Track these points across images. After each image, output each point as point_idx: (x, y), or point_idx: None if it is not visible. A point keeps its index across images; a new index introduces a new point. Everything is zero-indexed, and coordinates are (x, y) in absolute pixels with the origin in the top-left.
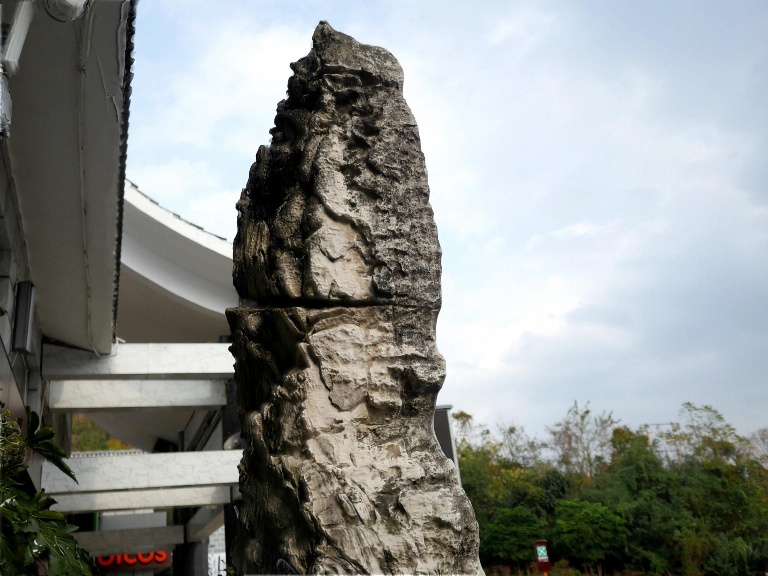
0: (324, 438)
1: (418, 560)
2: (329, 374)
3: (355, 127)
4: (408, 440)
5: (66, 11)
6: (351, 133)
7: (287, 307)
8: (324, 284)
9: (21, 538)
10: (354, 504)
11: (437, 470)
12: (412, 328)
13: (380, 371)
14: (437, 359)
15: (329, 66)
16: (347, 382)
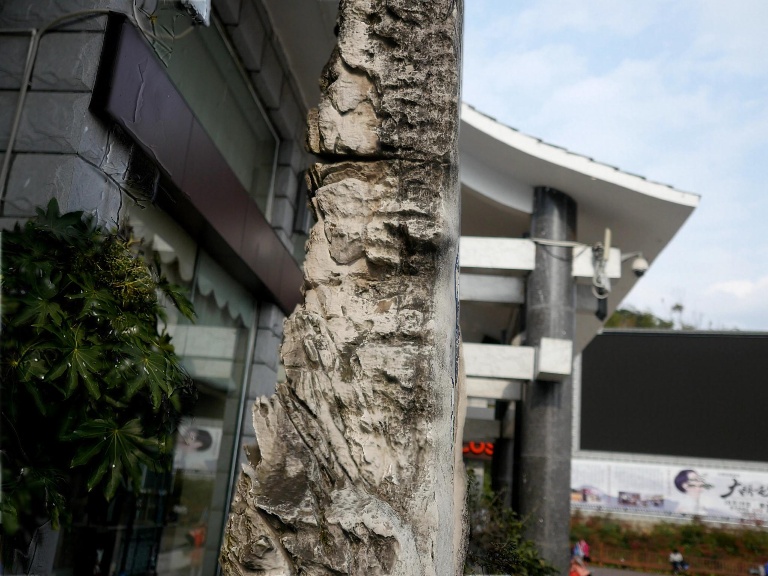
0: (321, 289)
1: (365, 410)
2: (329, 228)
3: None
4: (402, 298)
5: None
6: None
7: (313, 164)
8: (329, 138)
9: (113, 356)
10: (319, 350)
11: (412, 328)
12: (420, 184)
13: (376, 226)
14: (439, 216)
15: None
16: (342, 236)
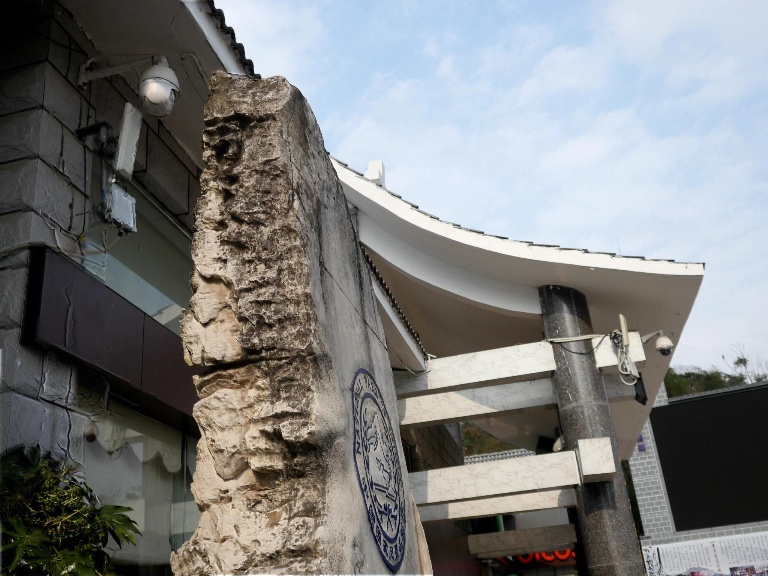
0: (212, 510)
1: None
2: (210, 444)
3: (219, 180)
4: (292, 505)
5: (156, 110)
6: None
7: None
8: (195, 353)
9: None
10: None
11: (299, 541)
12: (291, 380)
13: (252, 435)
14: None
15: (208, 121)
16: (221, 451)
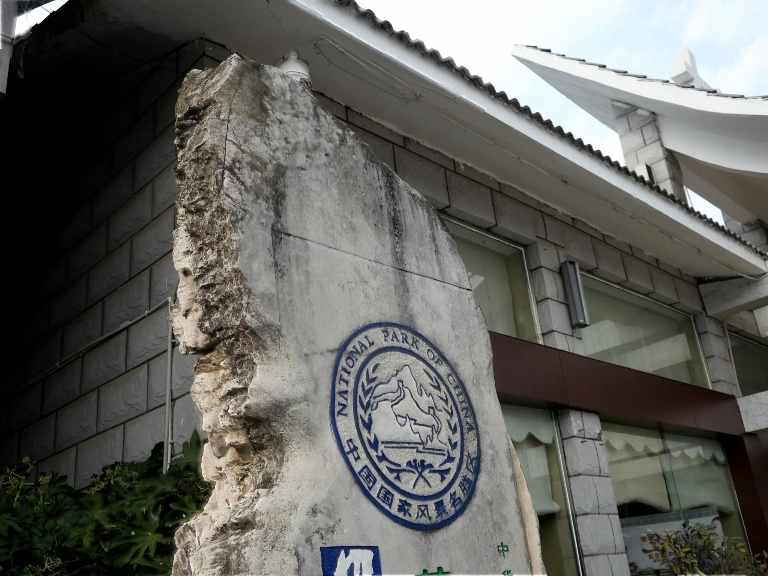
0: None
1: None
2: None
3: None
4: (256, 477)
5: None
6: None
7: None
8: None
9: None
10: (189, 558)
11: (241, 513)
12: (243, 356)
13: None
14: None
15: None
16: (206, 432)
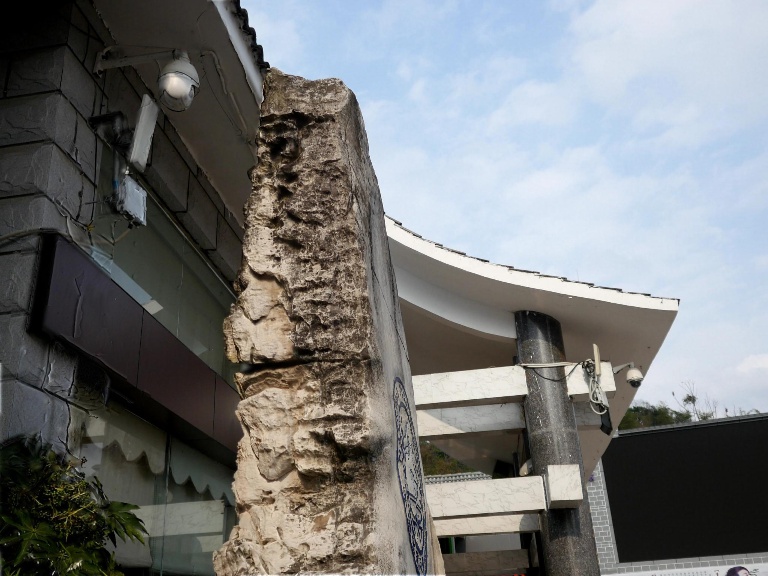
0: (253, 511)
1: None
2: (255, 443)
3: (276, 177)
4: (339, 509)
5: (175, 105)
6: (276, 183)
7: None
8: (244, 349)
9: None
10: None
11: (351, 546)
12: (343, 383)
13: (301, 436)
14: (365, 417)
15: (264, 117)
16: (268, 451)
